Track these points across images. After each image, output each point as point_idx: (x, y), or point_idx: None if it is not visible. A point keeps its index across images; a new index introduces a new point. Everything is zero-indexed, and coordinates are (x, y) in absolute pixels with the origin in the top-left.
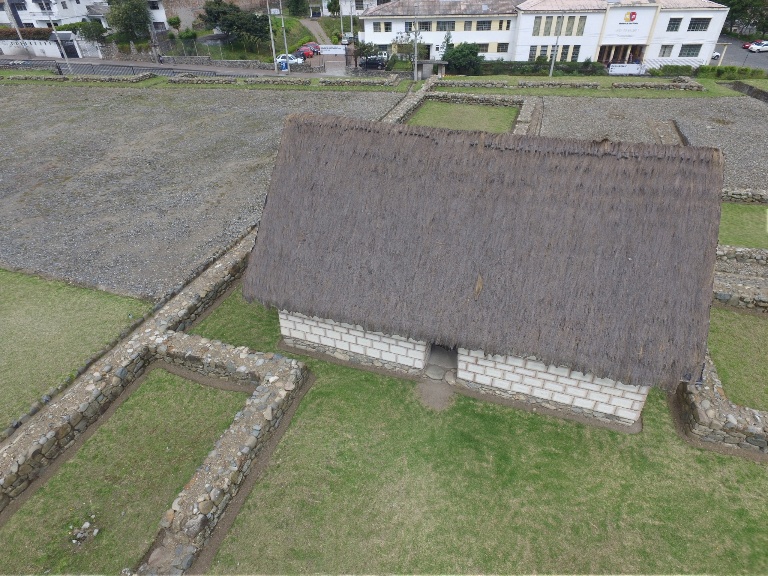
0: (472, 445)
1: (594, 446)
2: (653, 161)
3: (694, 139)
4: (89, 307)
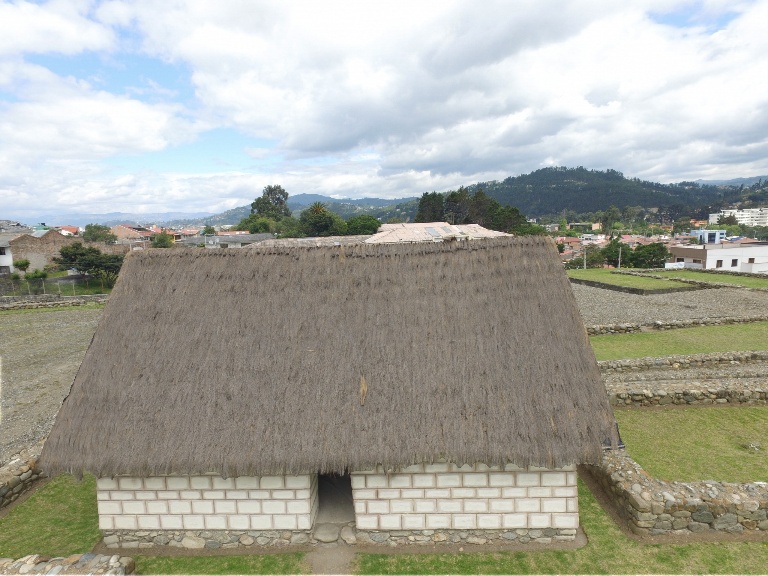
0: None
1: (544, 575)
2: (499, 249)
3: None
4: None
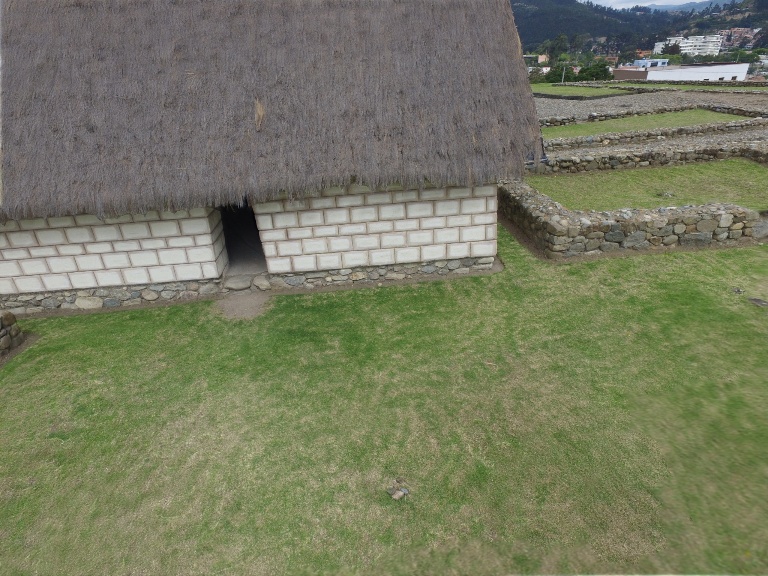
0: (307, 339)
1: (460, 295)
2: None
3: None
4: None
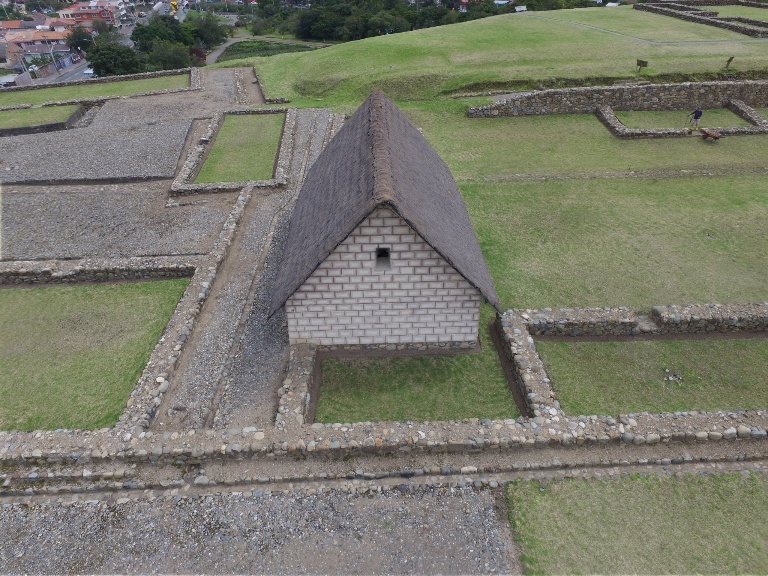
0: (486, 253)
1: None
2: None
3: (42, 177)
4: (568, 567)
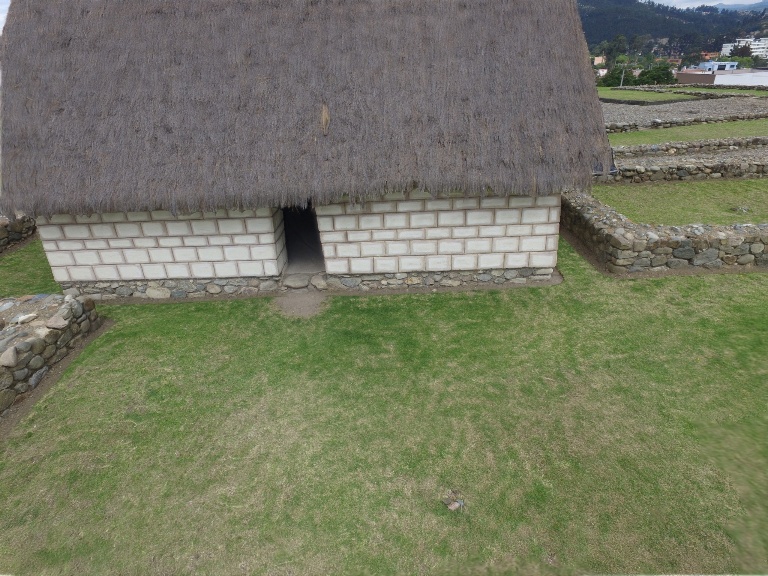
0: (362, 340)
1: (517, 306)
2: None
3: None
4: None
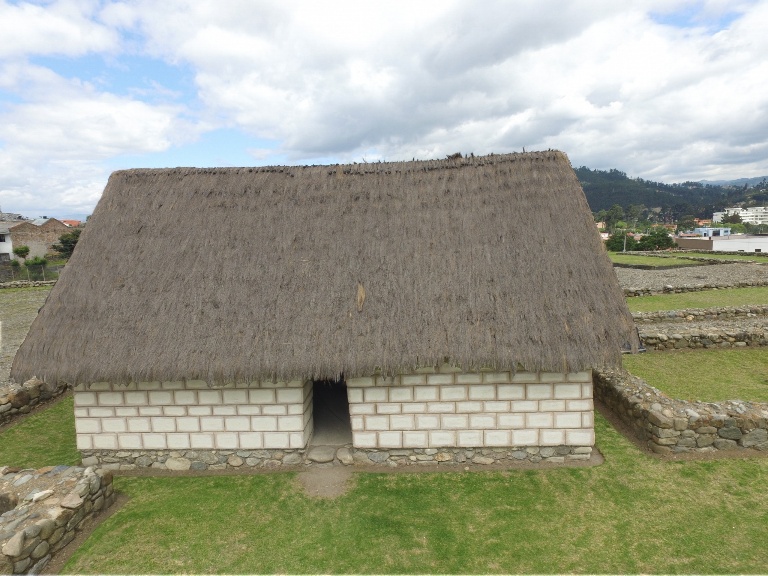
0: (391, 530)
1: (558, 491)
2: (507, 164)
3: None
4: None
